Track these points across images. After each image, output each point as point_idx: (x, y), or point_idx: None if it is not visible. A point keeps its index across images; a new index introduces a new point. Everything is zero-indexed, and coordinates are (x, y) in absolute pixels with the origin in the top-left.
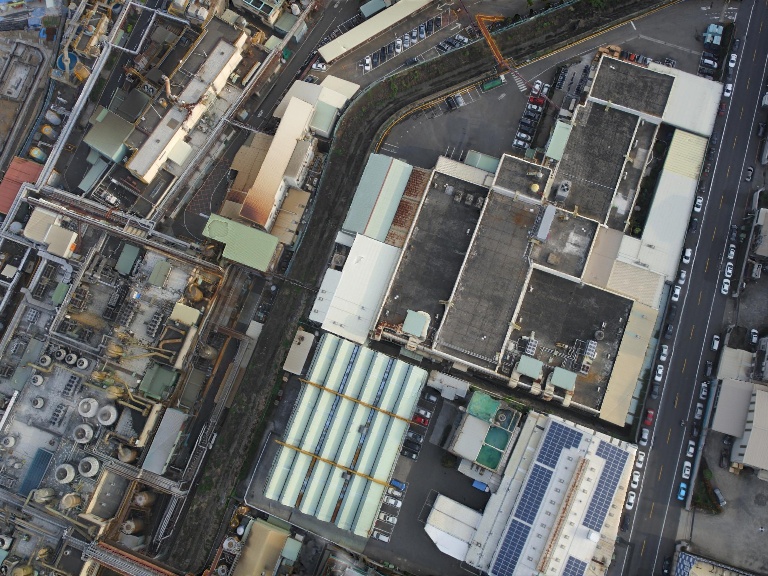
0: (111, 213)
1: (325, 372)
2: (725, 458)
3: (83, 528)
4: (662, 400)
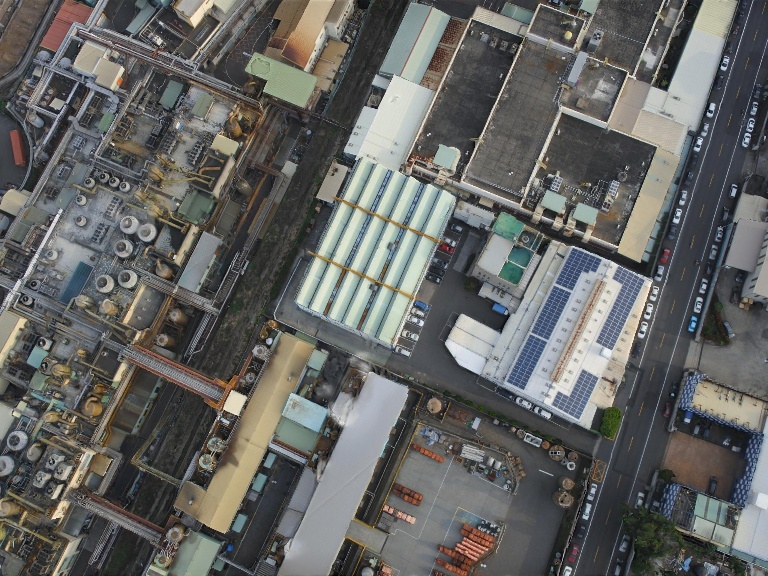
0: (157, 53)
1: (358, 193)
2: (736, 294)
3: (120, 332)
4: (678, 241)
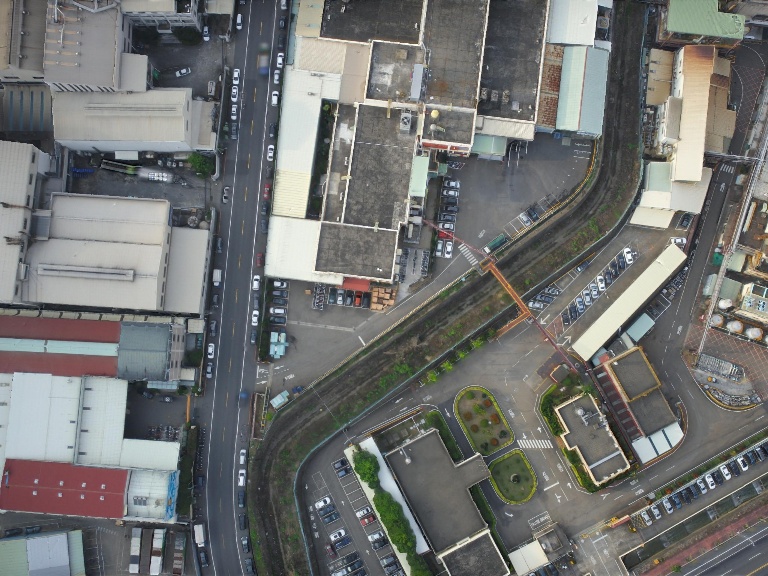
0: None
1: None
2: None
3: None
4: None
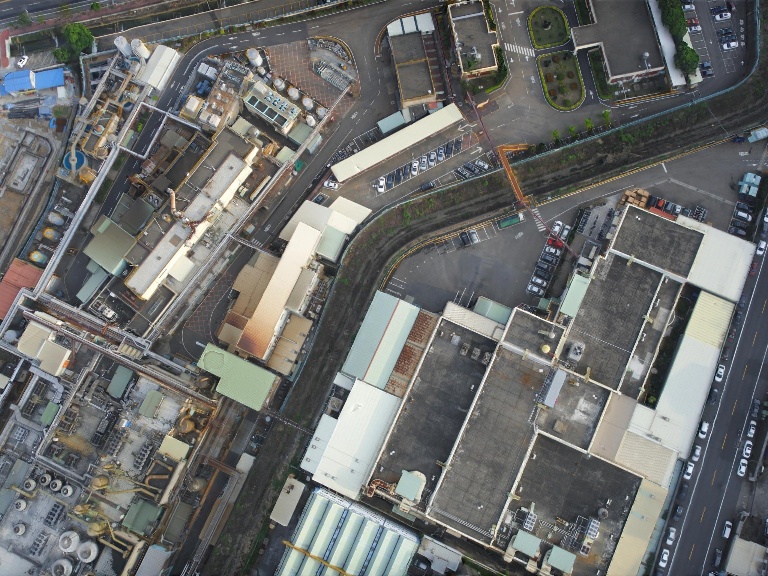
0: (107, 328)
1: (311, 536)
2: None
3: None
4: None
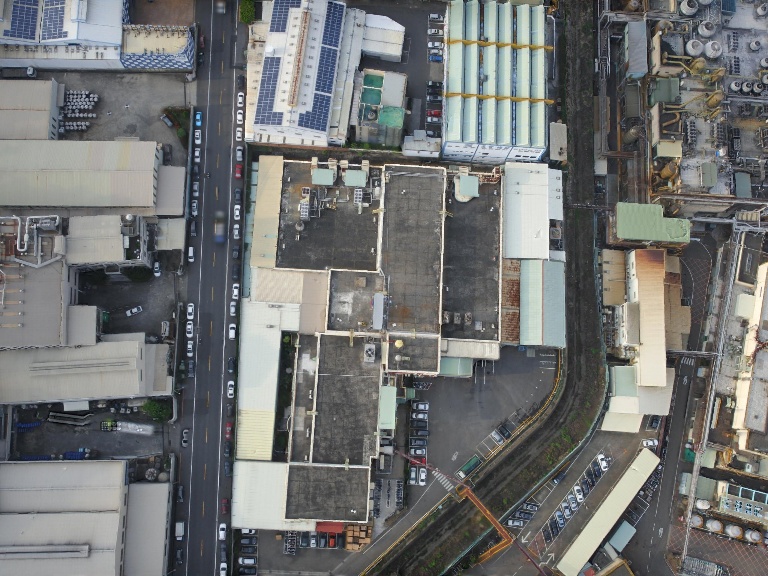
0: None
1: (533, 115)
2: (168, 152)
3: None
4: (230, 190)
